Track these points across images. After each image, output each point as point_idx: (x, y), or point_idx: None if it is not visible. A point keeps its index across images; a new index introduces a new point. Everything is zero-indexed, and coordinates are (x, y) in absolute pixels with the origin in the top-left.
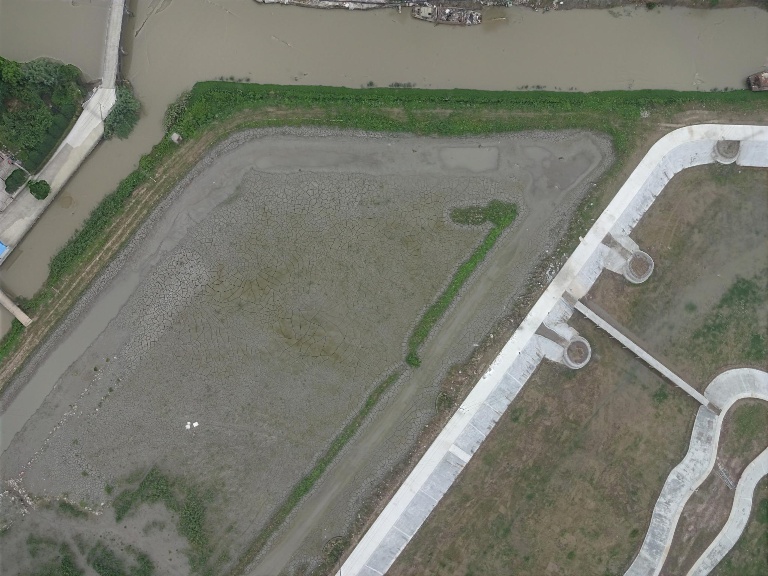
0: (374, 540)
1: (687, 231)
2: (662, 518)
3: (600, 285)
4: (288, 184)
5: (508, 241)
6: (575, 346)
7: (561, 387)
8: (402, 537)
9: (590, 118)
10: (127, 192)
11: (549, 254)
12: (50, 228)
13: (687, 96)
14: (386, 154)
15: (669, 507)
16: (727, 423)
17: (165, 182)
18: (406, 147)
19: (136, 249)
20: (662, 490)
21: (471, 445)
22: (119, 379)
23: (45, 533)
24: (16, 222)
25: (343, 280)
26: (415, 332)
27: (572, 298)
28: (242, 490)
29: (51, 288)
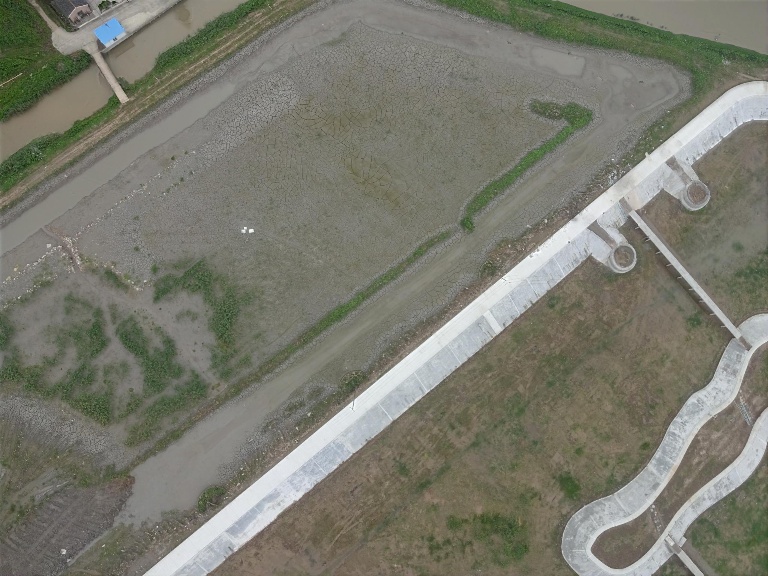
0: (393, 381)
1: (746, 176)
2: (676, 436)
3: (656, 203)
4: (389, 42)
5: (578, 142)
6: (623, 250)
7: (601, 287)
8: (420, 388)
9: (675, 53)
10: (244, 12)
11: (614, 162)
12: (166, 28)
13: (767, 58)
14: (483, 39)
15: (685, 427)
16: (755, 360)
17: (280, 12)
18: (502, 37)
19: (238, 63)
20: (680, 410)
21: (505, 318)
22: (192, 172)
23: (84, 295)
24: (138, 14)
25: (419, 137)
26: (475, 199)
27: (628, 206)
28: (279, 303)
29: (153, 77)
